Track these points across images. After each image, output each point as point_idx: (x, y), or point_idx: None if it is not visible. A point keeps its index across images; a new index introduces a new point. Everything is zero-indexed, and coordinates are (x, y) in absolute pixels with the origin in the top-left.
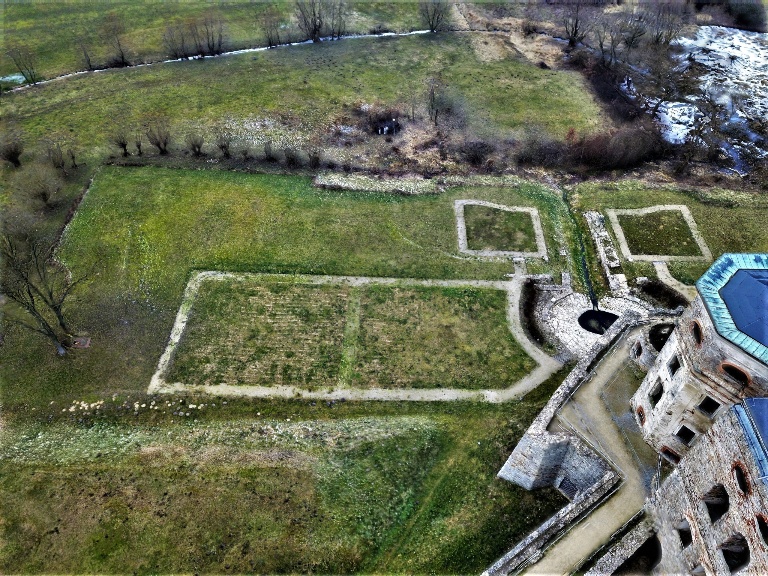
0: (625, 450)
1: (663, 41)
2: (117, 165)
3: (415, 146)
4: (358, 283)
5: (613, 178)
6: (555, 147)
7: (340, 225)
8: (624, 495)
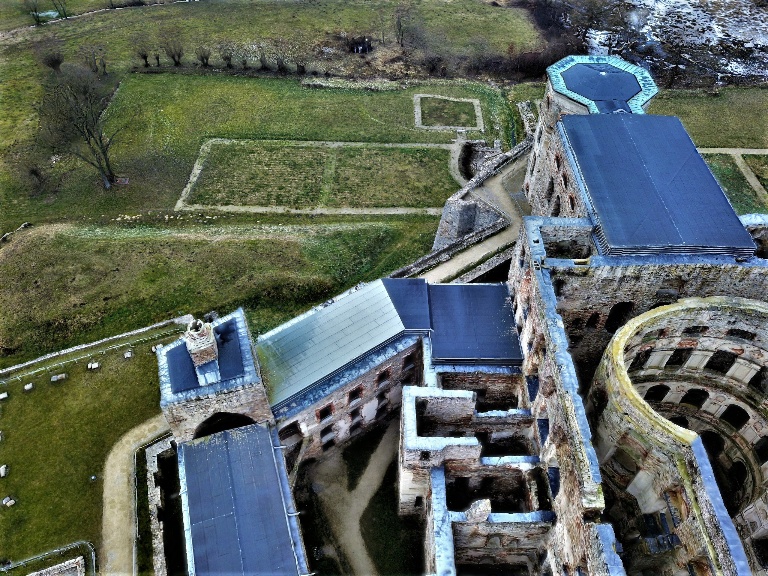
0: (515, 209)
1: None
2: (140, 73)
3: (384, 61)
4: (334, 146)
5: (543, 81)
6: None
7: (321, 110)
8: (510, 231)
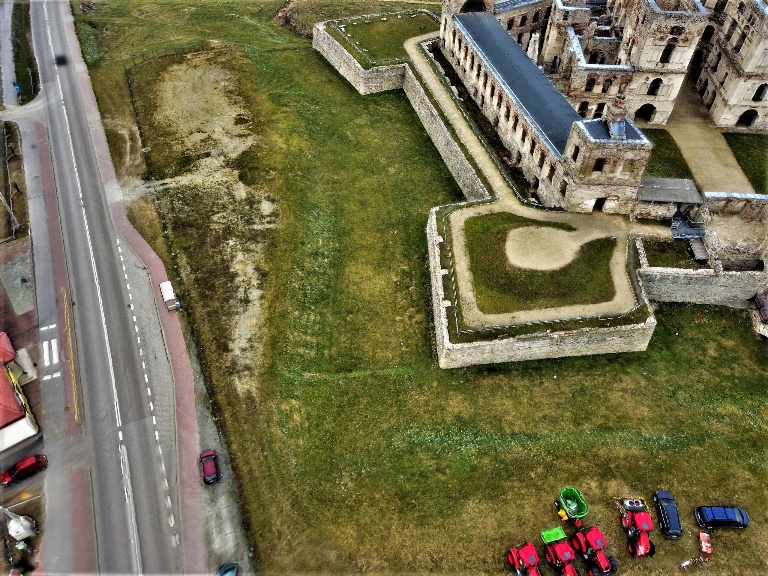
0: None
1: None
2: None
3: None
4: None
5: None
6: None
7: None
8: None
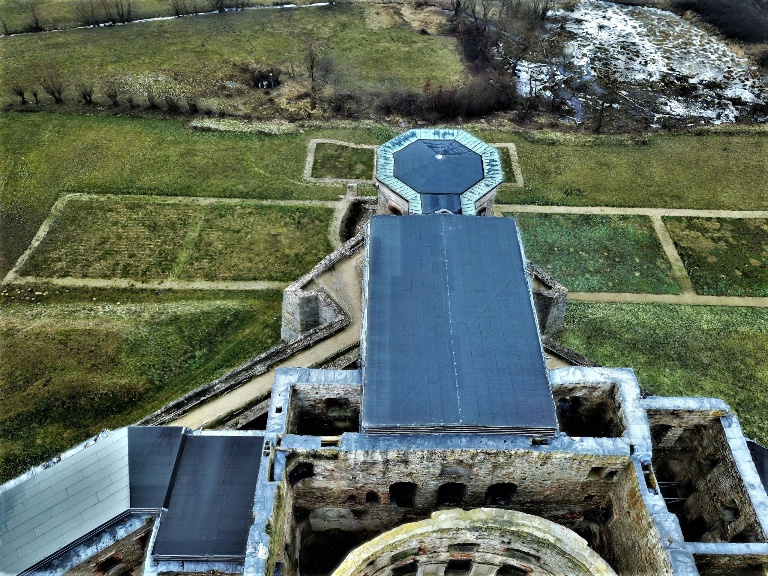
0: None
1: (541, 12)
2: (14, 111)
3: (290, 98)
4: (206, 202)
5: (459, 123)
6: (415, 98)
7: (201, 158)
8: (348, 332)
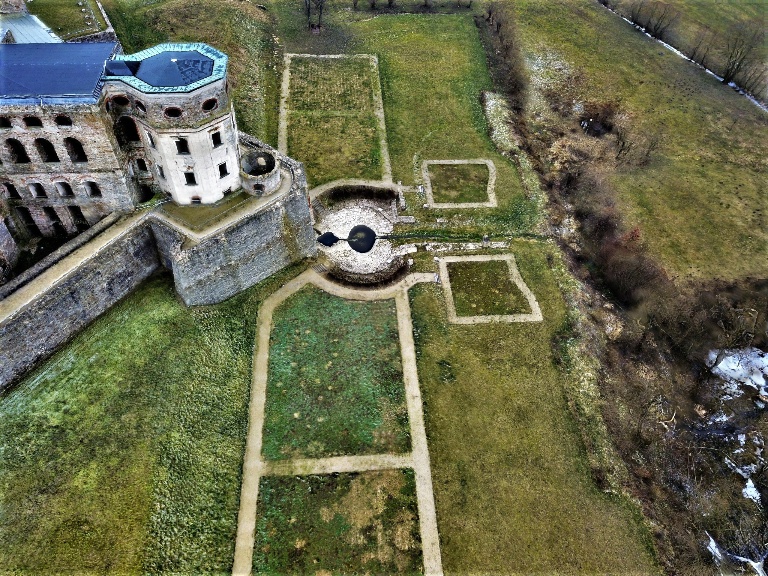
0: None
1: None
2: None
3: (574, 146)
4: (377, 113)
5: (582, 276)
6: (620, 236)
7: (436, 103)
8: None
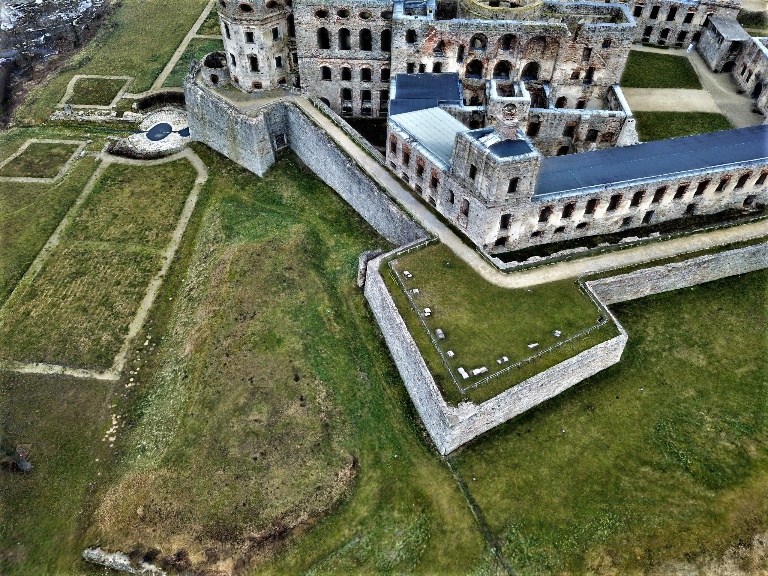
0: (273, 98)
1: None
2: None
3: None
4: (56, 241)
5: (19, 101)
6: None
7: None
8: None
